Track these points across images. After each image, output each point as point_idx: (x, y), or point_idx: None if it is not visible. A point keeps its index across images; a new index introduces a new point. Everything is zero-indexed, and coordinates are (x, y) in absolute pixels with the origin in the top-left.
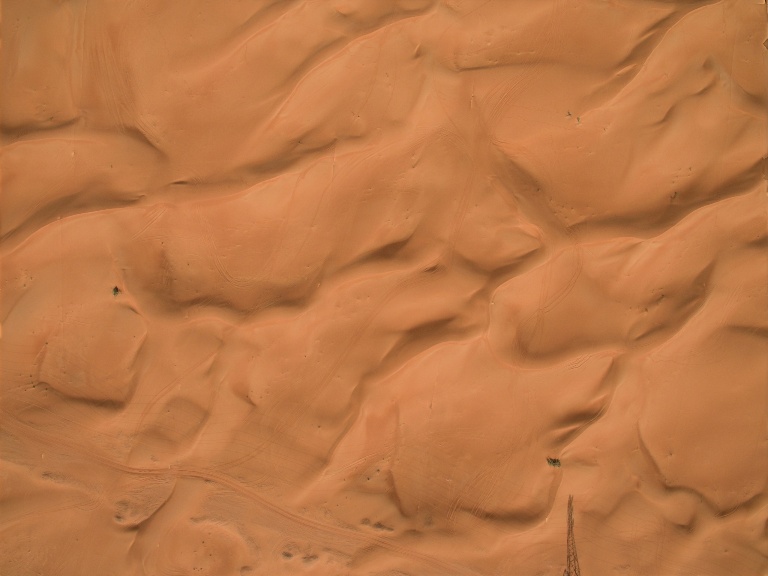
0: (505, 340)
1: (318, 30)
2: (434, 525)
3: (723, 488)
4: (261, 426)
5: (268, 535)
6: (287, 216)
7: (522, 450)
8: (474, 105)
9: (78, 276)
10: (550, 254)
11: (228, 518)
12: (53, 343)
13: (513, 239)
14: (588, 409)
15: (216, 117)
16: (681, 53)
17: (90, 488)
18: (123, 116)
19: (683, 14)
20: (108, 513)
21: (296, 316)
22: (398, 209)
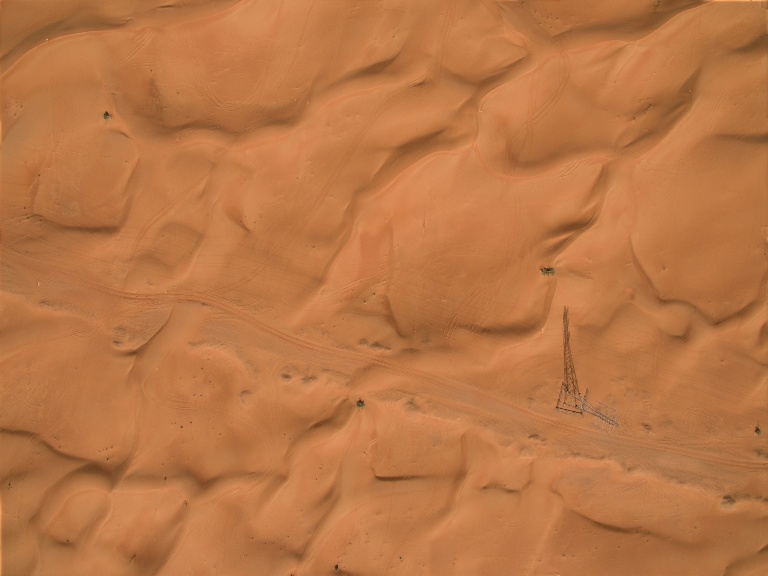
0: (495, 150)
1: None
2: (431, 342)
3: (717, 299)
4: (256, 250)
5: (266, 358)
6: (274, 36)
7: (516, 263)
8: None
9: (68, 102)
10: (536, 61)
11: (226, 342)
12: (46, 175)
13: (499, 49)
14: (580, 219)
15: None
16: None
17: (87, 314)
18: None
19: None
20: (106, 339)
21: (286, 134)
22: (384, 27)
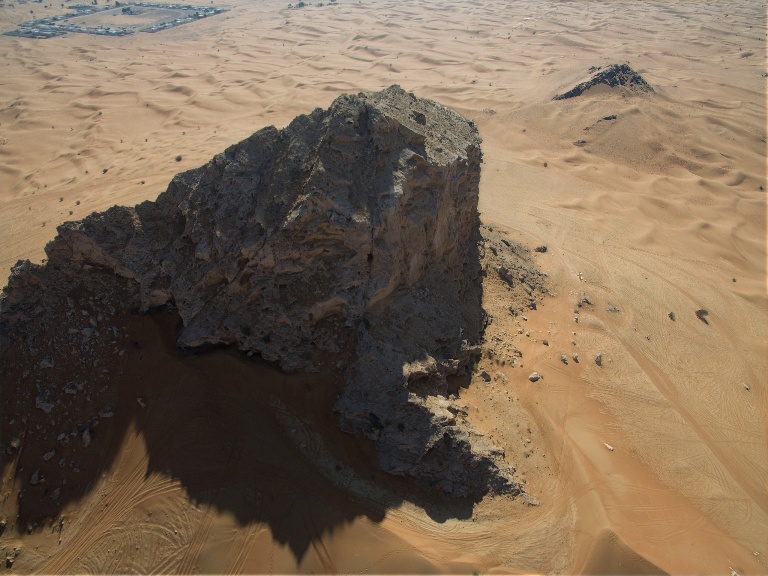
0: None
1: None
2: None
3: None
4: None
5: None
6: None
7: None
8: None
9: None
10: None
11: None
12: None
13: None
14: None
15: None
16: None
17: (649, 1)
18: None
19: None
20: None
21: None
22: None
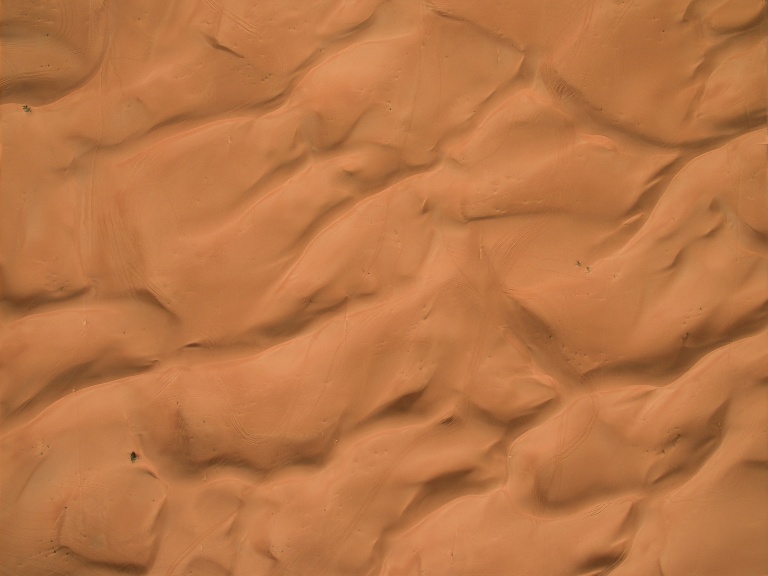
0: (524, 490)
1: (325, 191)
2: None
3: None
4: None
5: None
6: (301, 374)
7: None
8: (483, 255)
9: (95, 444)
10: (565, 404)
11: None
12: (72, 507)
13: (528, 389)
14: (609, 552)
15: (226, 279)
16: (687, 197)
17: None
18: (133, 280)
19: (688, 160)
20: None
21: (314, 474)
22: (412, 361)
